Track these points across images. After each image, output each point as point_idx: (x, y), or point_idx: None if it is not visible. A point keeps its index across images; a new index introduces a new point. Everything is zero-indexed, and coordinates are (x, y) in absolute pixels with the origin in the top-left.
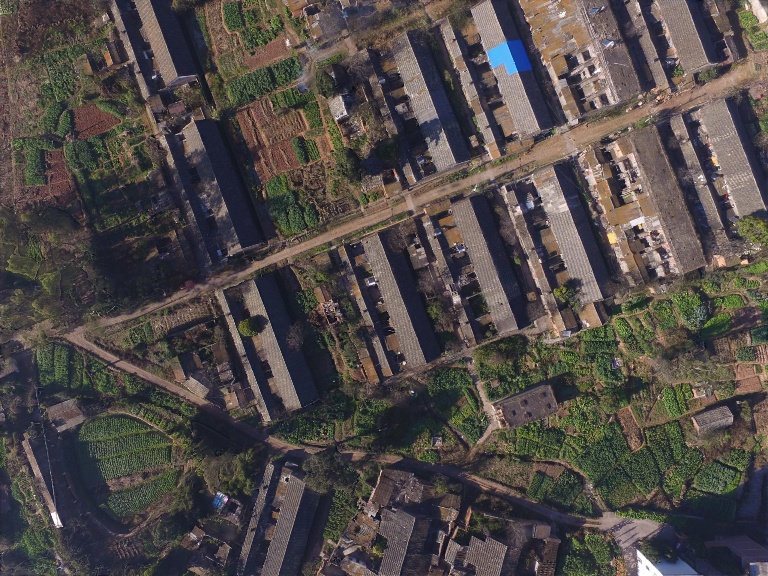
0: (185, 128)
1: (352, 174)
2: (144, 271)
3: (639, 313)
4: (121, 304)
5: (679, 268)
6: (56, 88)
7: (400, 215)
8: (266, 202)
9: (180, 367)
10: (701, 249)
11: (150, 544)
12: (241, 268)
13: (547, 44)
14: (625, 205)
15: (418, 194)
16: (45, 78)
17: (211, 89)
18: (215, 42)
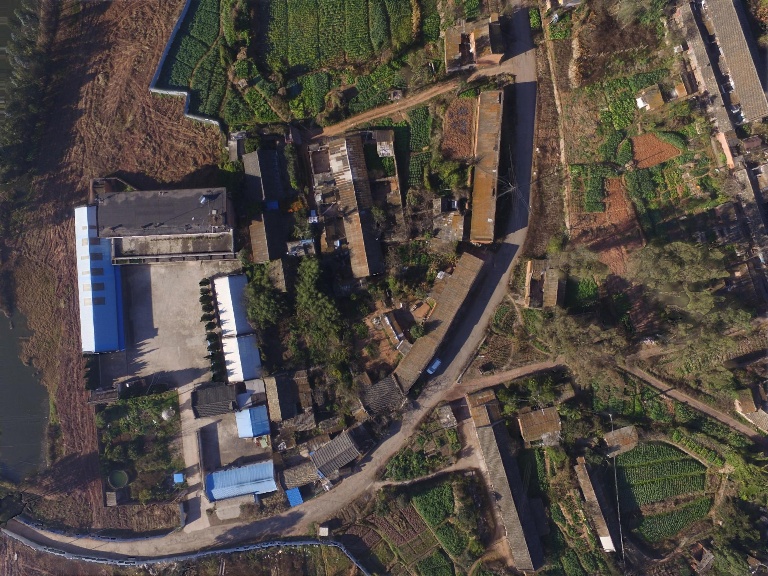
0: None
1: None
2: None
3: None
4: None
5: None
6: (617, 116)
7: None
8: None
9: (751, 399)
10: None
11: (687, 570)
12: None
13: None
14: None
15: None
16: (603, 106)
17: None
18: None
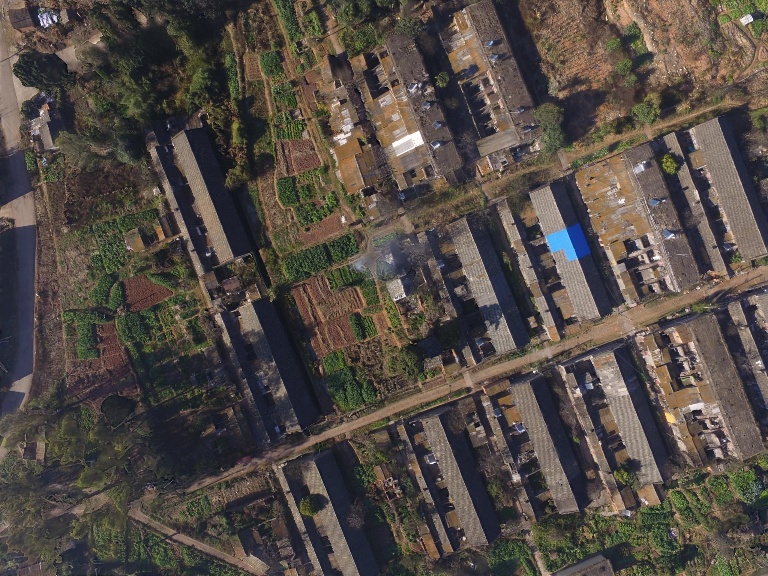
0: (241, 307)
1: None
2: (200, 444)
3: (695, 487)
4: (178, 479)
5: (739, 455)
6: (106, 260)
7: (458, 392)
8: (323, 377)
9: (240, 545)
10: (760, 436)
11: None
12: (298, 442)
13: (606, 229)
14: (684, 389)
15: (476, 371)
16: (94, 249)
17: (266, 264)
18: (269, 217)
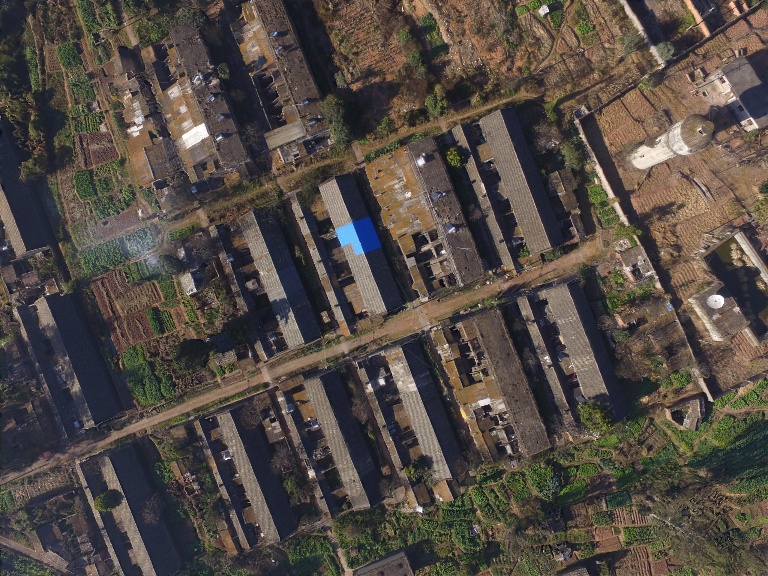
0: (37, 302)
1: (195, 362)
2: (4, 440)
3: (494, 484)
4: None
5: (524, 451)
6: None
7: (256, 387)
8: (123, 372)
9: (38, 541)
10: (545, 432)
11: None
12: (100, 437)
13: (394, 223)
14: (473, 385)
15: (274, 366)
16: None
17: (65, 258)
18: (68, 210)
